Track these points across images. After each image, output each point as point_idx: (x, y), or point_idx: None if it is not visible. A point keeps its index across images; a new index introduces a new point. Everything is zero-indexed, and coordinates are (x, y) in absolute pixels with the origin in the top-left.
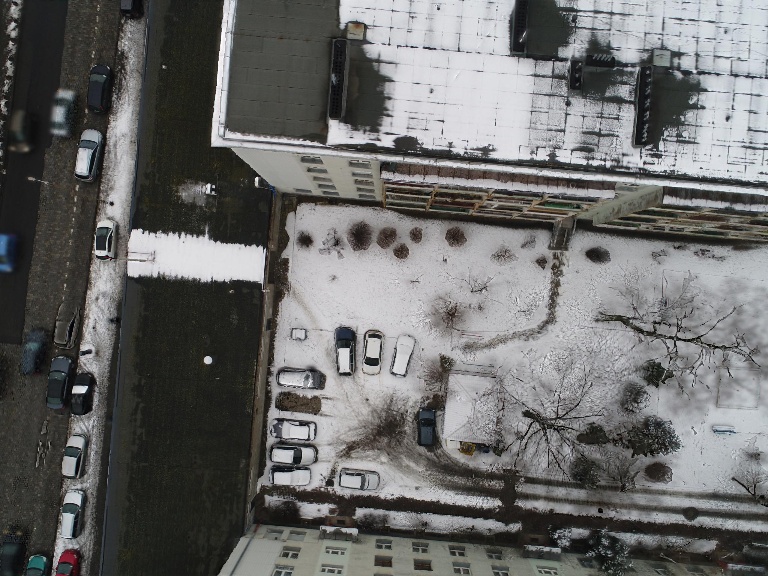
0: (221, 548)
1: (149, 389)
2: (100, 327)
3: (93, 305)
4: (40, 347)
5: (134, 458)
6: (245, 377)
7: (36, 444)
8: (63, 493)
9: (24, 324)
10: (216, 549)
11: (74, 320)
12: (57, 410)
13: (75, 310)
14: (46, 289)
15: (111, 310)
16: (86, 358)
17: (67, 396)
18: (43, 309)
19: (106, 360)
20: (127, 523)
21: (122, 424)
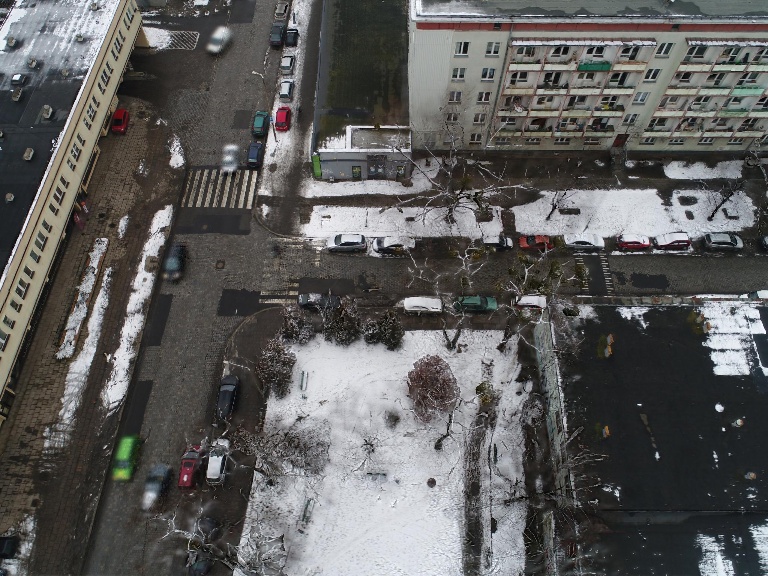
0: (395, 70)
1: (343, 5)
2: (301, 13)
3: (296, 5)
4: (264, 23)
5: (336, 32)
6: (399, 1)
7: (260, 64)
8: (278, 85)
9: (254, 15)
10: (392, 71)
11: (287, 5)
12: (274, 48)
13: (288, 3)
14: (268, 1)
15: (308, 6)
16: (293, 26)
17: (282, 38)
18: (266, 8)
19: (305, 26)
20: (334, 60)
21: (328, 18)
